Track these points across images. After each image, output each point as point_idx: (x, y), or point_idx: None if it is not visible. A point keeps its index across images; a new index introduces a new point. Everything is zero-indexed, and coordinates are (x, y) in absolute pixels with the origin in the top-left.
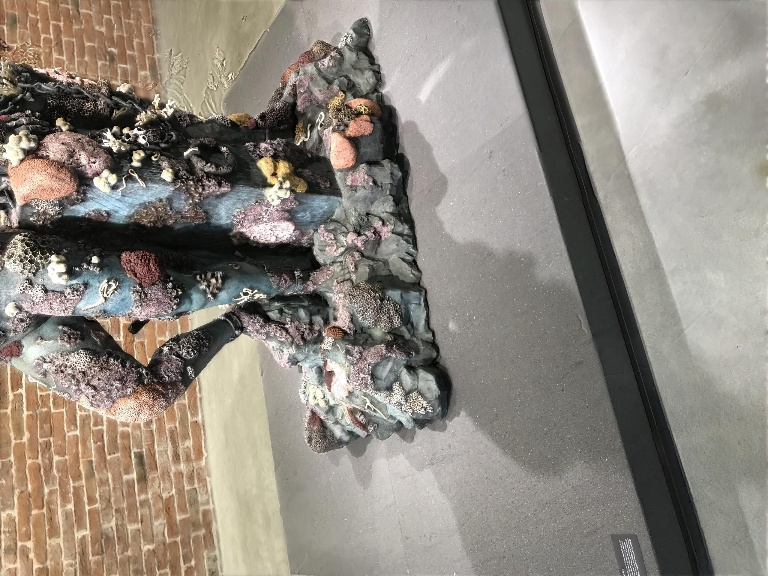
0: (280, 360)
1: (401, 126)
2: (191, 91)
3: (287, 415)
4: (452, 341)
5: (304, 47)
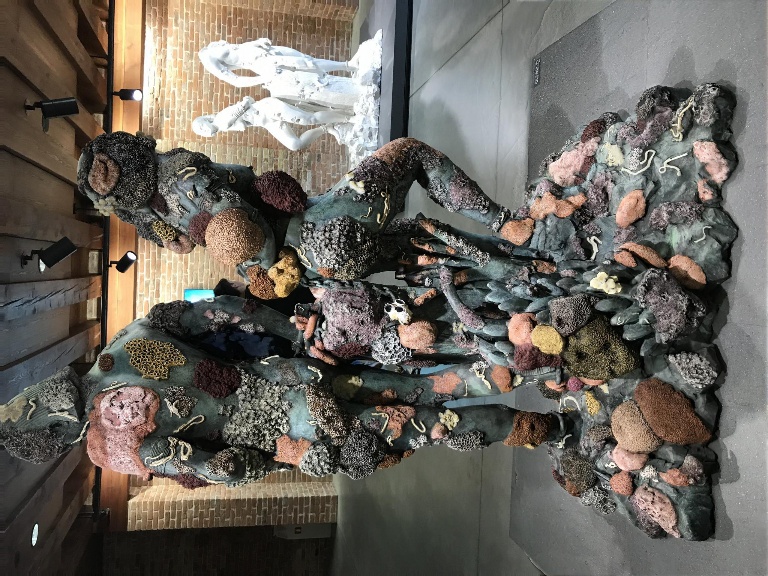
0: (542, 188)
1: None
2: None
3: None
4: None
5: (630, 569)
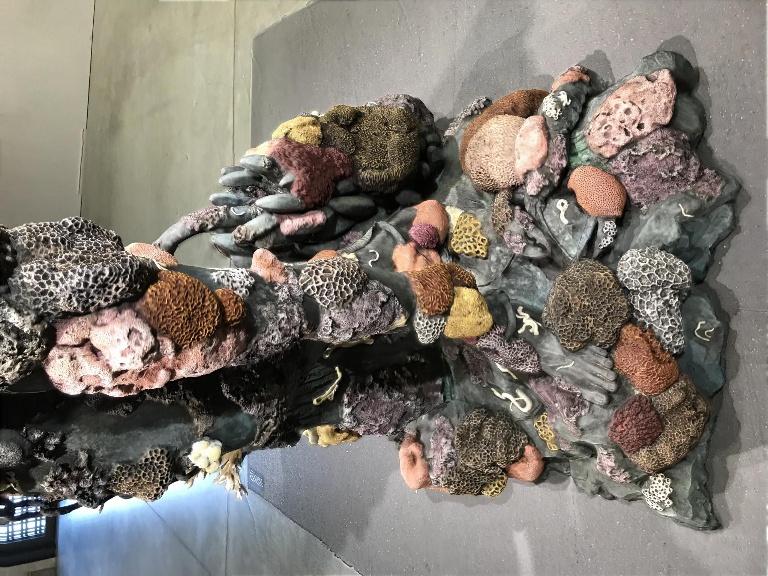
0: None
1: (512, 479)
2: None
3: (343, 52)
4: None
5: None
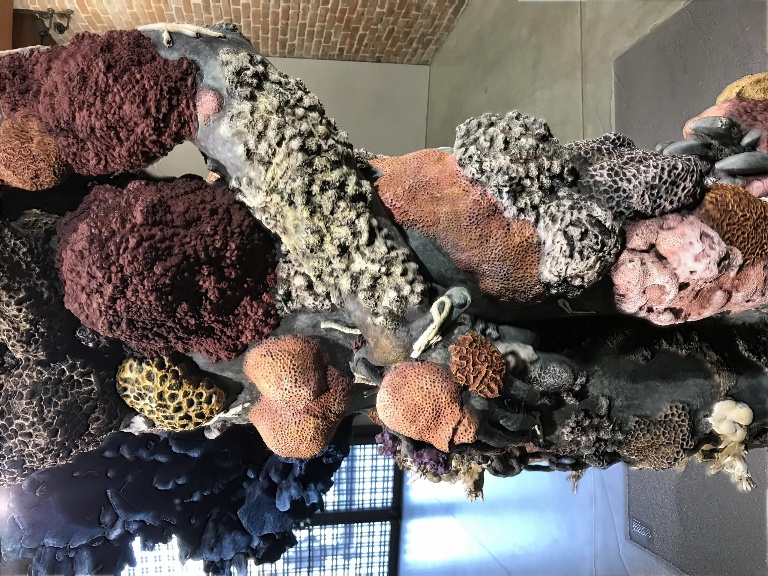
0: None
1: None
2: None
3: (740, 38)
4: (767, 450)
5: None
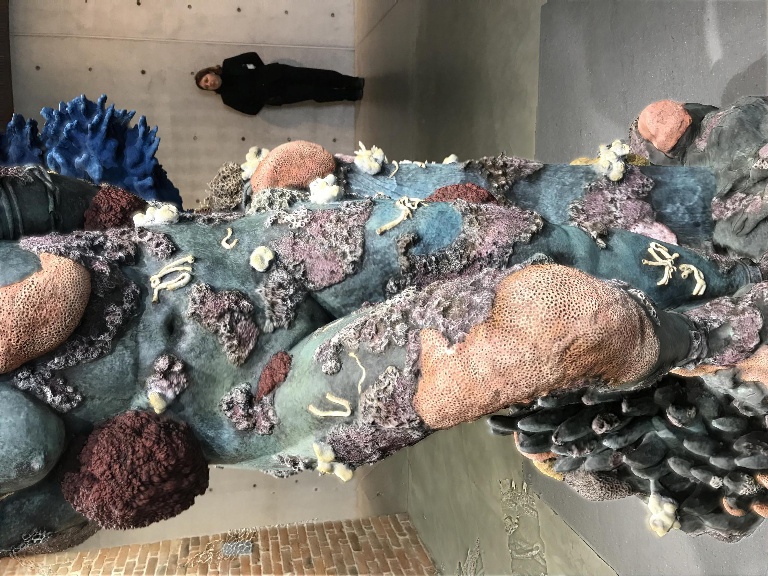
0: None
1: None
2: (495, 571)
3: None
4: None
5: None
